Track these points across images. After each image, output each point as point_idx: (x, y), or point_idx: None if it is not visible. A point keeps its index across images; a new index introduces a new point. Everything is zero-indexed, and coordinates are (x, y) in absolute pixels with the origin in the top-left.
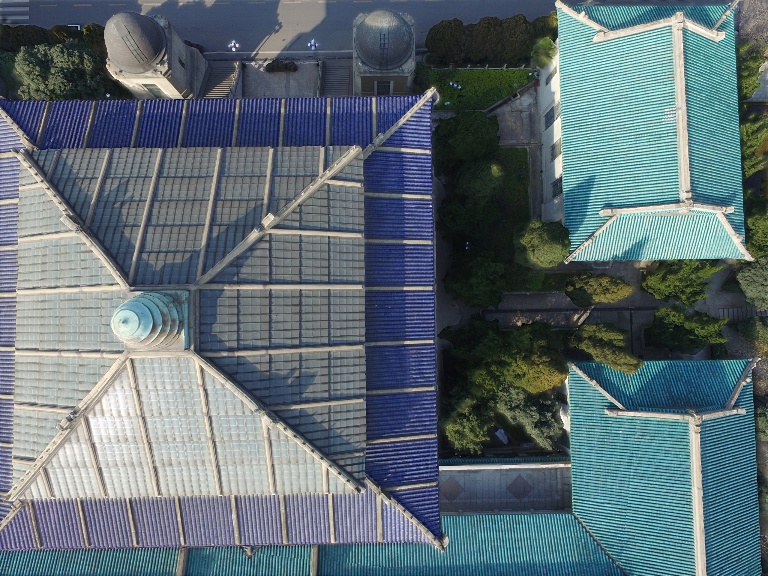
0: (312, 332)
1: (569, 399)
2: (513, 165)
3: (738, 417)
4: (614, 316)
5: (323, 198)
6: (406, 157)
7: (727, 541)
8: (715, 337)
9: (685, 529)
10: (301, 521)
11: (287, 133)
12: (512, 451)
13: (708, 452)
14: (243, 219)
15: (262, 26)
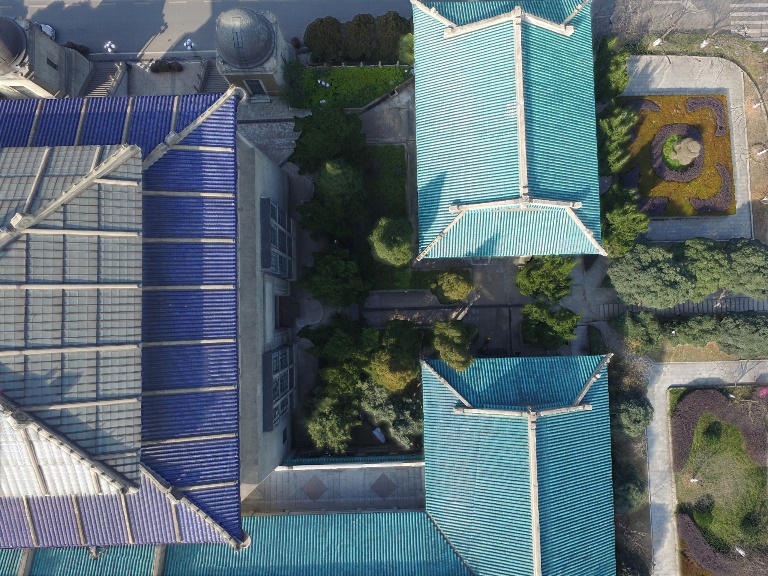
0: (77, 332)
1: (423, 397)
2: (389, 162)
3: (589, 413)
4: (493, 313)
5: (92, 197)
6: (206, 155)
7: (572, 538)
8: (568, 333)
9: (524, 526)
10: (97, 522)
11: (85, 133)
12: (387, 450)
13: (550, 449)
14: (2, 219)
15: (148, 26)
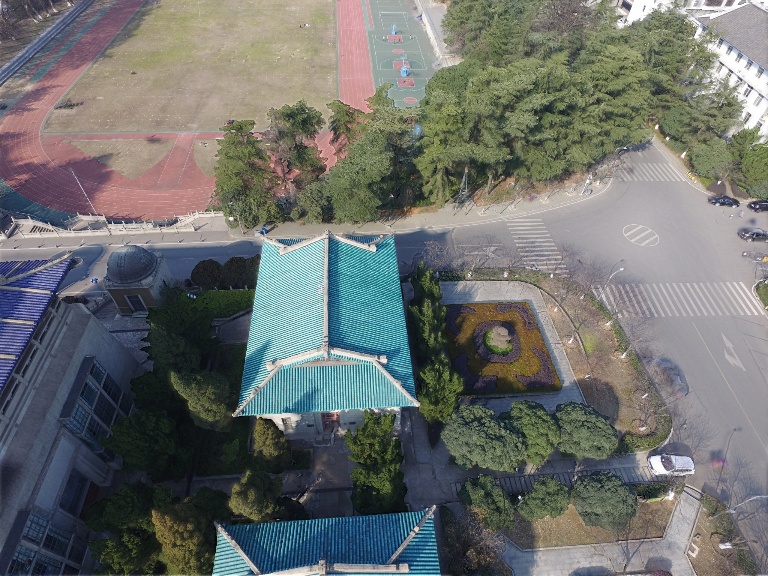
0: None
1: (212, 575)
2: (242, 356)
3: None
4: (334, 498)
5: None
6: (25, 295)
7: None
8: (385, 484)
9: None
10: None
11: None
12: None
13: None
14: None
15: (72, 277)
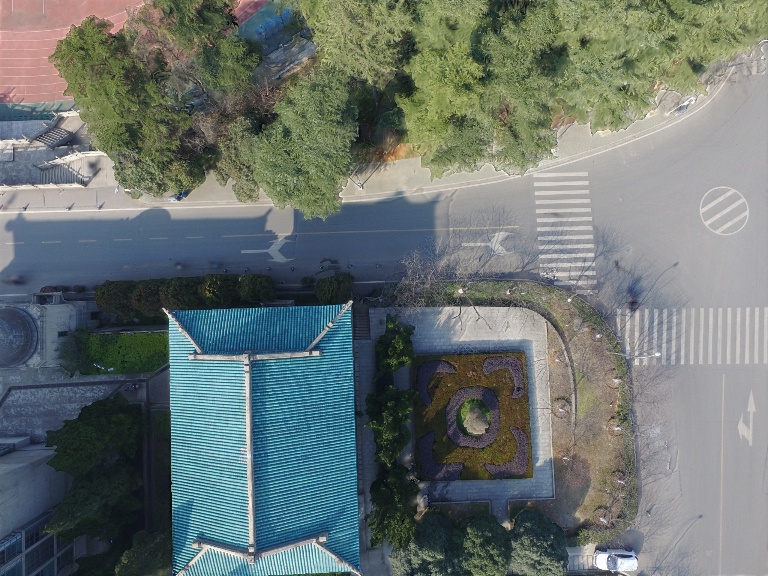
0: None
1: None
2: None
3: None
4: None
5: None
6: None
7: None
8: None
9: None
10: None
11: None
12: None
13: None
14: None
15: None
